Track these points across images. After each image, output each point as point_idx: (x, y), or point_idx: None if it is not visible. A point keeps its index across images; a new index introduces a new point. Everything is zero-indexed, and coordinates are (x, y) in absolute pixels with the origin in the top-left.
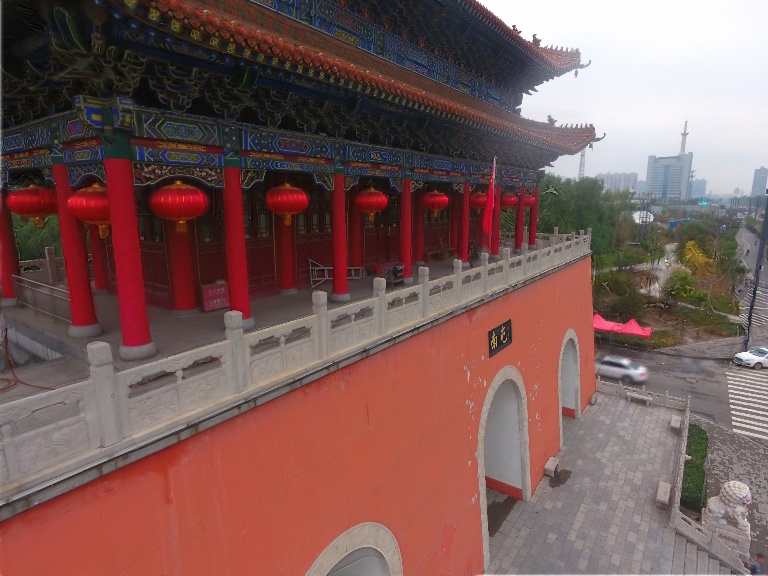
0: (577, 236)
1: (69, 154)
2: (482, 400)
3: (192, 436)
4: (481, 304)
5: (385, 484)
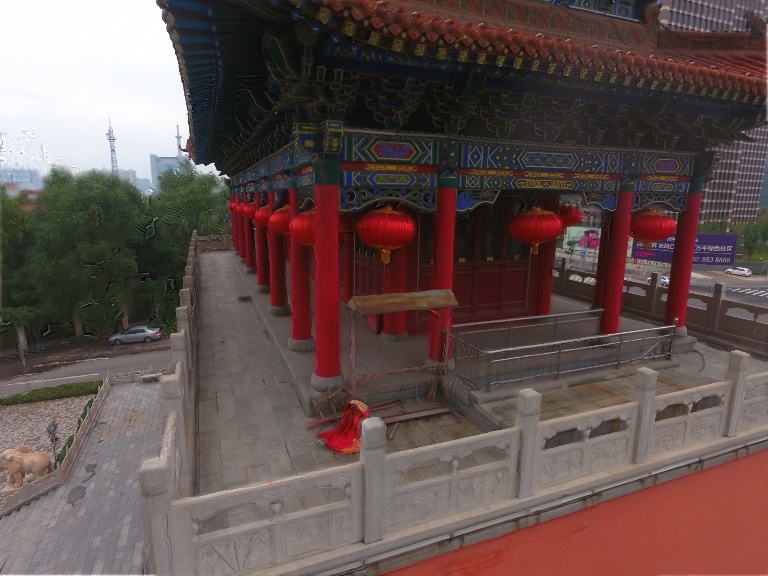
0: None
1: (646, 184)
2: None
3: None
4: None
5: None
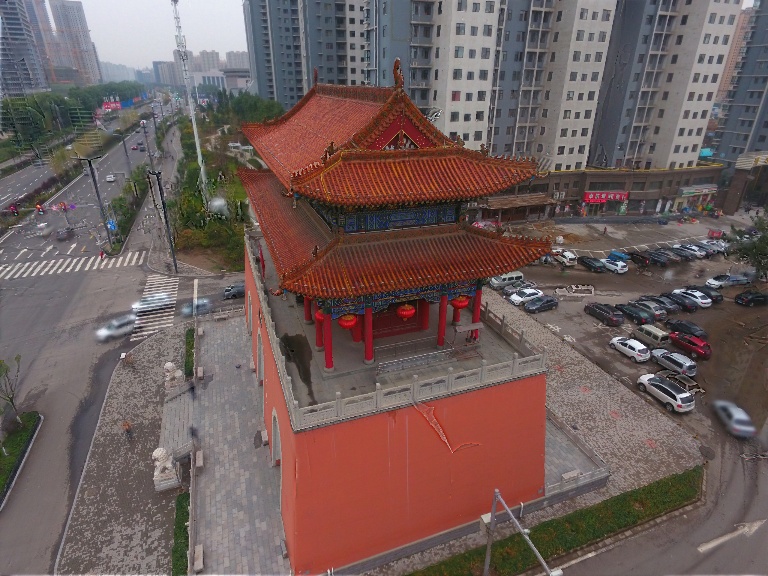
0: (311, 407)
1: None
2: None
3: None
4: None
5: None
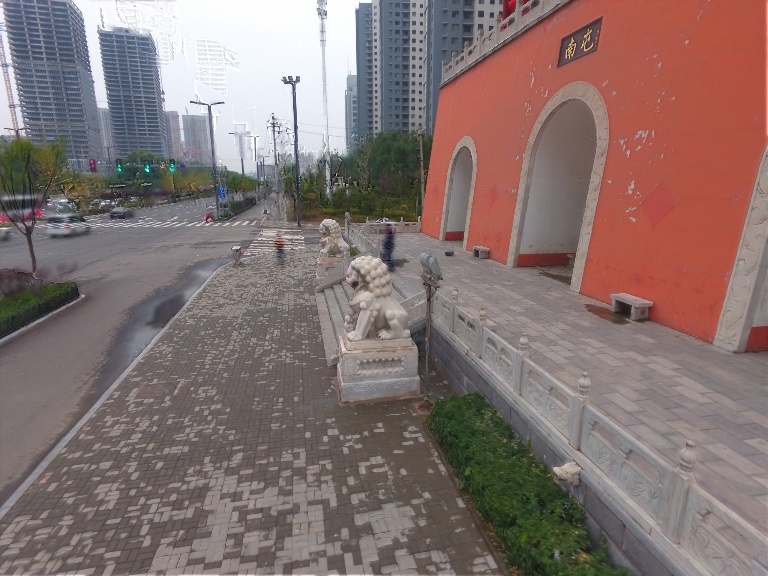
0: None
1: None
2: (540, 110)
3: (457, 78)
4: (557, 10)
5: (480, 128)
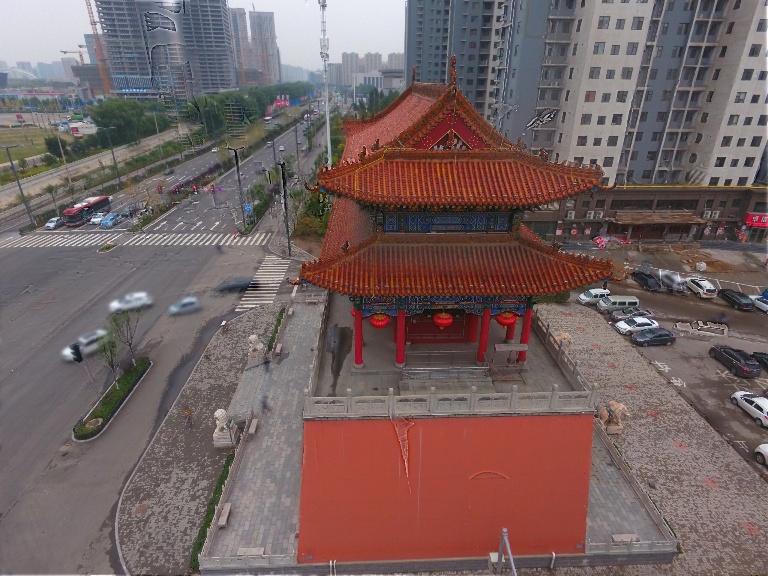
0: (321, 398)
1: None
2: None
3: None
4: None
5: None
